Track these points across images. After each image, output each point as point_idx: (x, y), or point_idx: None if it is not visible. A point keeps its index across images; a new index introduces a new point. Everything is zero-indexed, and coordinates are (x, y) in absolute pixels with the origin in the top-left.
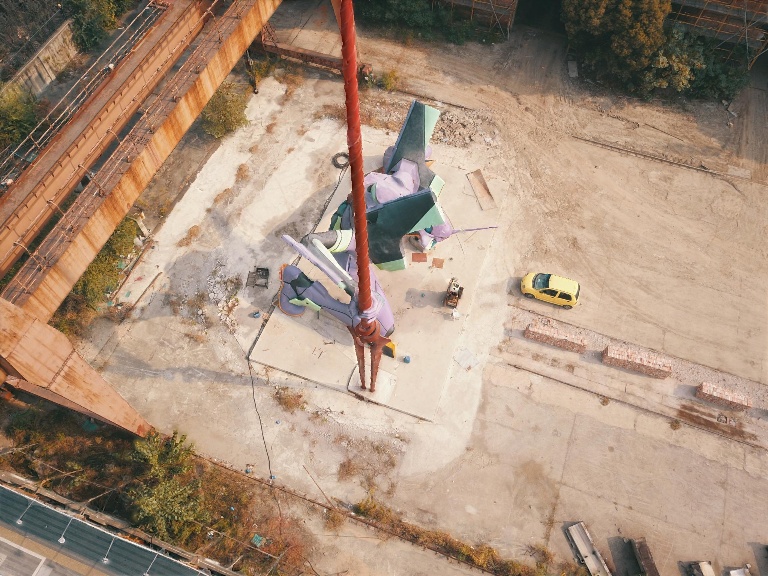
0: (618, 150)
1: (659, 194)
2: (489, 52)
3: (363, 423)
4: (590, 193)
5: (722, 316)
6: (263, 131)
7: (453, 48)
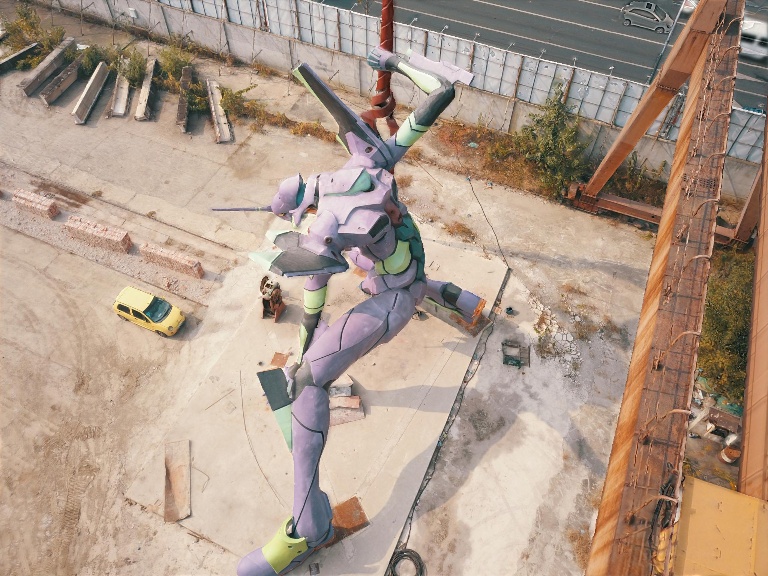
0: None
1: None
2: None
3: None
4: (3, 470)
5: None
6: None
7: None
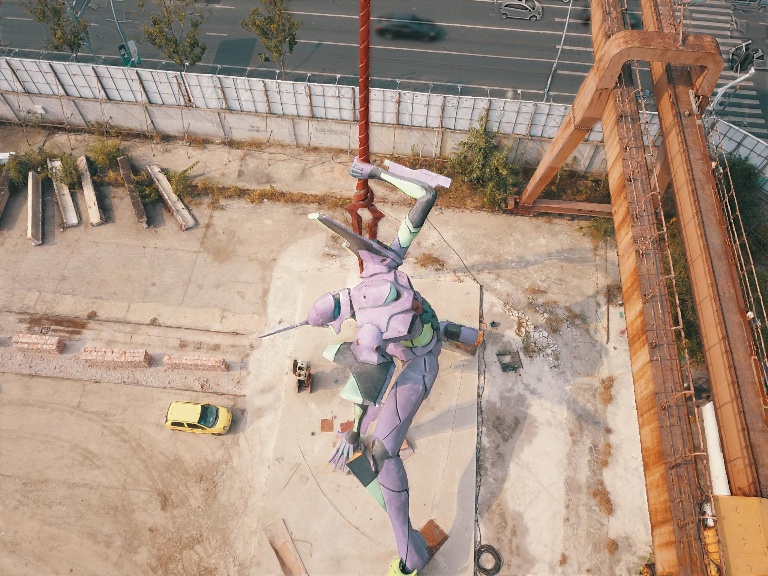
0: None
1: None
2: None
3: None
4: None
5: (7, 440)
6: None
7: None
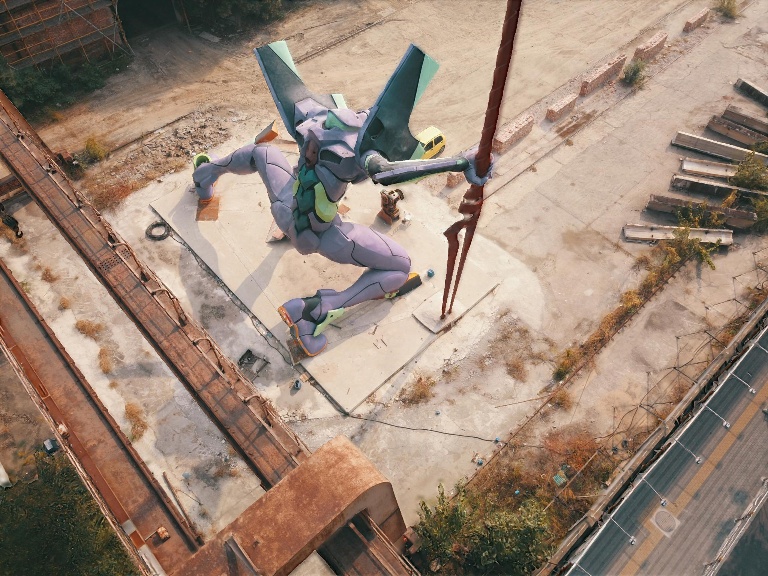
0: (316, 54)
1: (375, 56)
2: (134, 73)
3: (474, 338)
4: (344, 88)
5: None
6: (46, 286)
7: (102, 92)
